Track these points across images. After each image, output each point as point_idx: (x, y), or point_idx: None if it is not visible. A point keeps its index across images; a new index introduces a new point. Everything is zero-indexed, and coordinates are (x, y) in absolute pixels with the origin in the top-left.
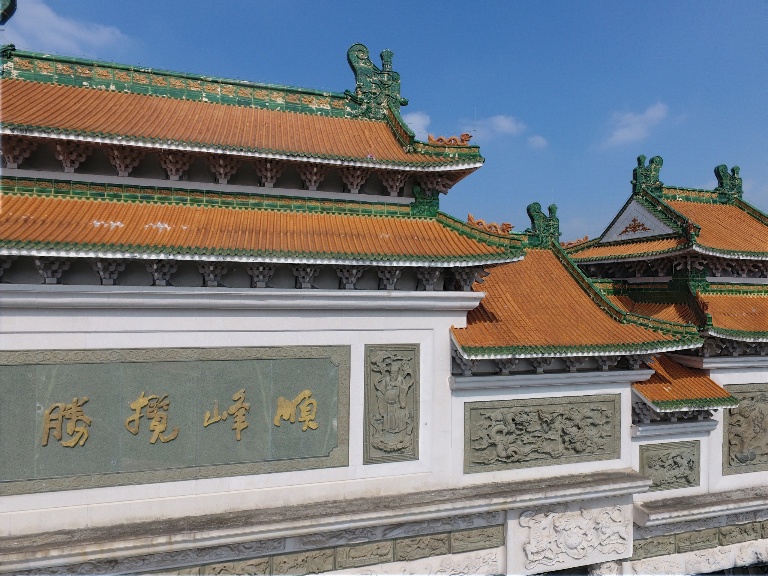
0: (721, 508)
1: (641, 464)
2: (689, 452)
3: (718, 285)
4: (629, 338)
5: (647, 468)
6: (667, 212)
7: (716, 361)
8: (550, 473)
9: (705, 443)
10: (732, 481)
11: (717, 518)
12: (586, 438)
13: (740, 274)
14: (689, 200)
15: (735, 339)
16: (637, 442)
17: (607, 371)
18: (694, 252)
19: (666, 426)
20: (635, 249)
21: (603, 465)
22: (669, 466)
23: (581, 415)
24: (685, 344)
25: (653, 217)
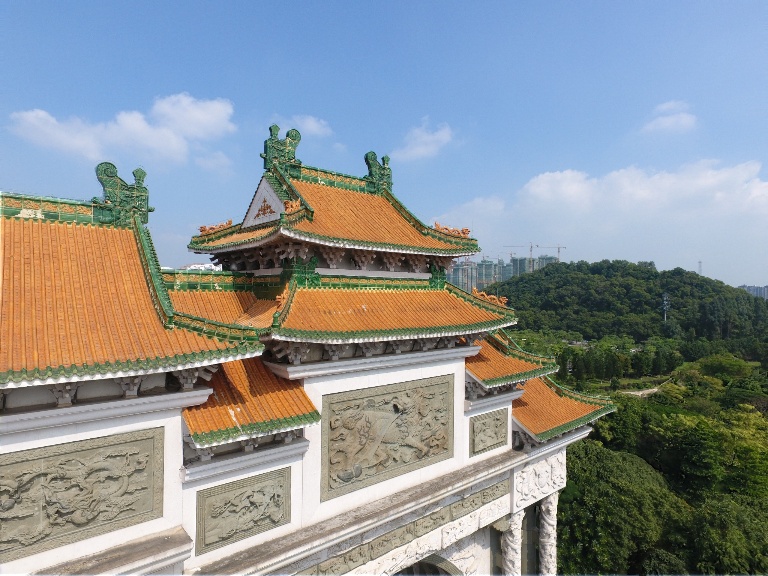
0: (303, 549)
1: (200, 516)
2: (273, 485)
3: (331, 278)
4: (161, 349)
5: (210, 519)
6: (289, 192)
7: (305, 369)
8: (16, 571)
9: (298, 469)
10: (333, 506)
11: (315, 554)
12: (95, 501)
13: (360, 266)
14: (333, 185)
15: (317, 342)
16: (193, 488)
17: (127, 399)
18: (287, 237)
19: (231, 460)
20: (256, 235)
21: (130, 533)
22: (244, 509)
23: (85, 468)
24: (237, 353)
25: (276, 197)
